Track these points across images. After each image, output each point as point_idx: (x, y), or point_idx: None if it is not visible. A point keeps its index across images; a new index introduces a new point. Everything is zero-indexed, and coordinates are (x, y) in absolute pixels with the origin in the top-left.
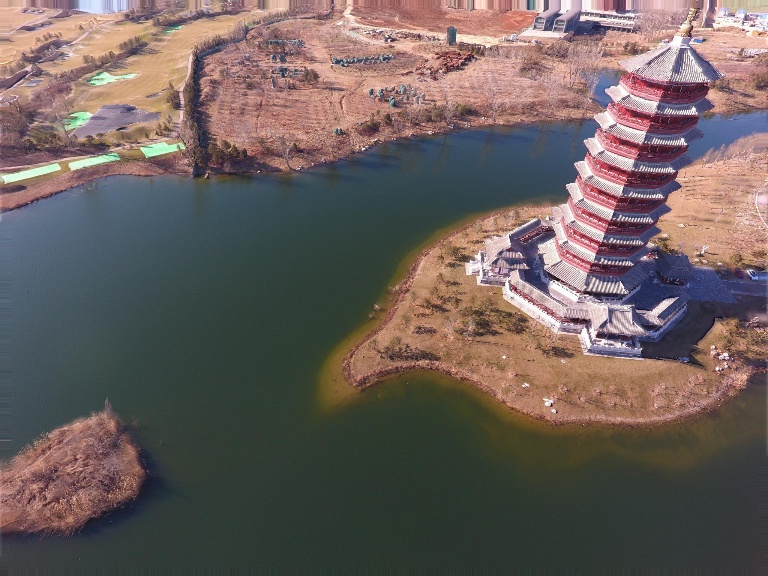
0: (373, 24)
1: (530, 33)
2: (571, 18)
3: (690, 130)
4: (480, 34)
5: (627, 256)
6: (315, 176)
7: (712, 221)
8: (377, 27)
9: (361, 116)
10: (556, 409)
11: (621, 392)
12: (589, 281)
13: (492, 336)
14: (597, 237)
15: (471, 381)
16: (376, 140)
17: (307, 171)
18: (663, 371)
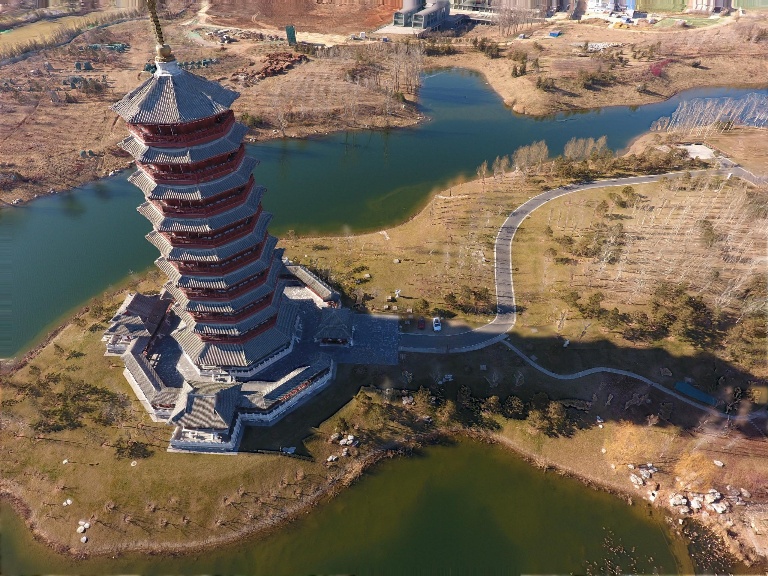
0: (223, 23)
1: (387, 30)
2: (433, 13)
3: (229, 176)
4: (330, 32)
5: (233, 323)
6: (28, 211)
7: (436, 253)
8: (224, 27)
9: None
10: (88, 536)
11: (182, 505)
12: (207, 351)
13: (70, 431)
14: (184, 304)
15: (9, 499)
16: (133, 162)
17: (24, 205)
18: (252, 470)
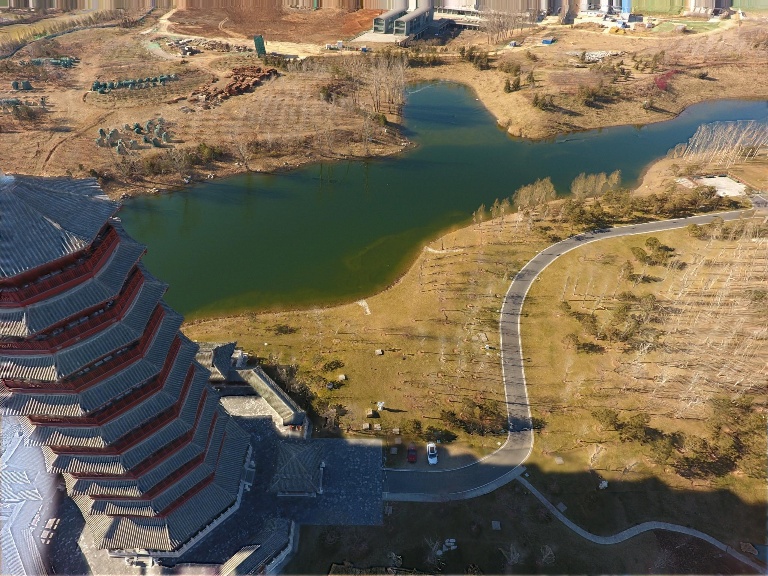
0: (186, 31)
1: (367, 37)
2: (415, 18)
3: (111, 328)
4: (304, 41)
5: None
6: None
7: (427, 338)
8: (188, 35)
9: (63, 172)
10: None
11: None
12: (117, 527)
13: None
14: (70, 482)
15: None
16: None
17: None
18: None
